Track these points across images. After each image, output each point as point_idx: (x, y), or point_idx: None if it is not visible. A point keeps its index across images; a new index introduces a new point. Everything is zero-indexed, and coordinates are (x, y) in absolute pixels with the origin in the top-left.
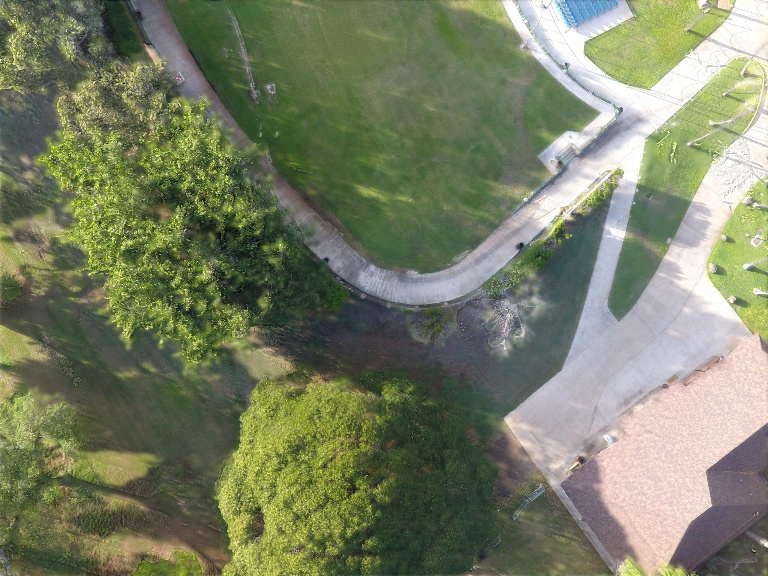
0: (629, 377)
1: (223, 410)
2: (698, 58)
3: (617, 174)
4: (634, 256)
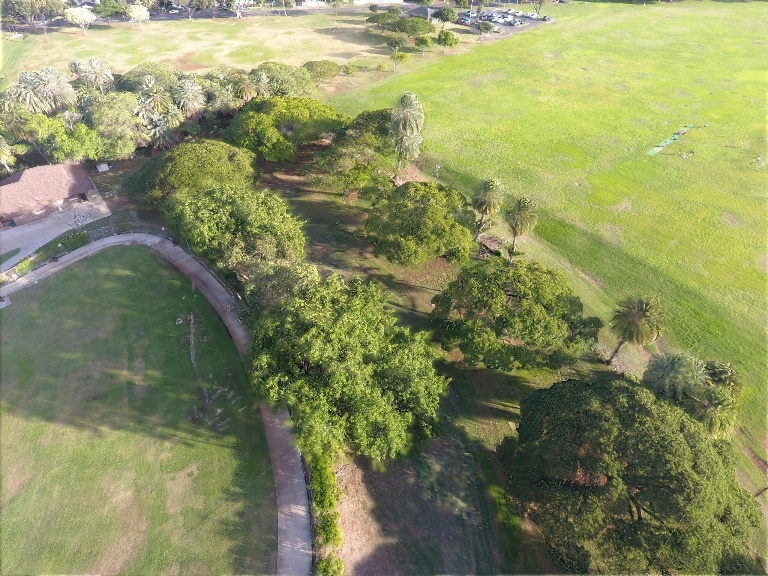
0: (31, 229)
1: None
2: None
3: None
4: None
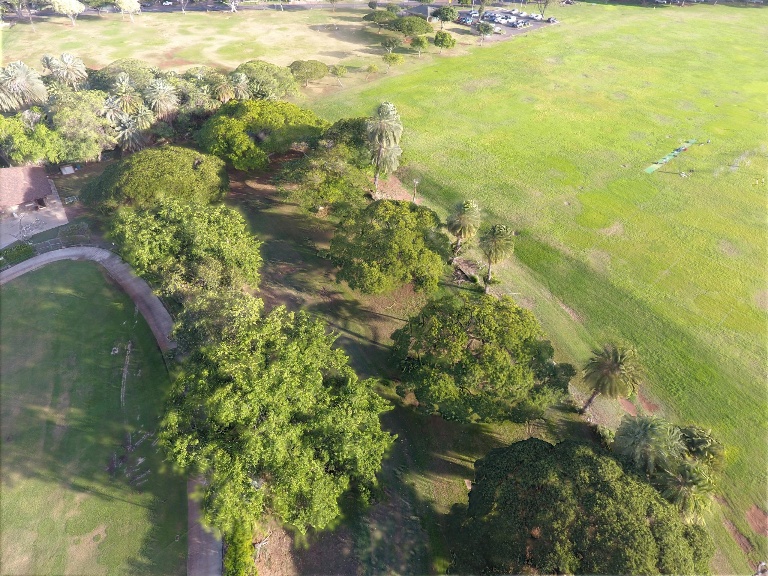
0: None
1: None
2: None
3: None
4: None
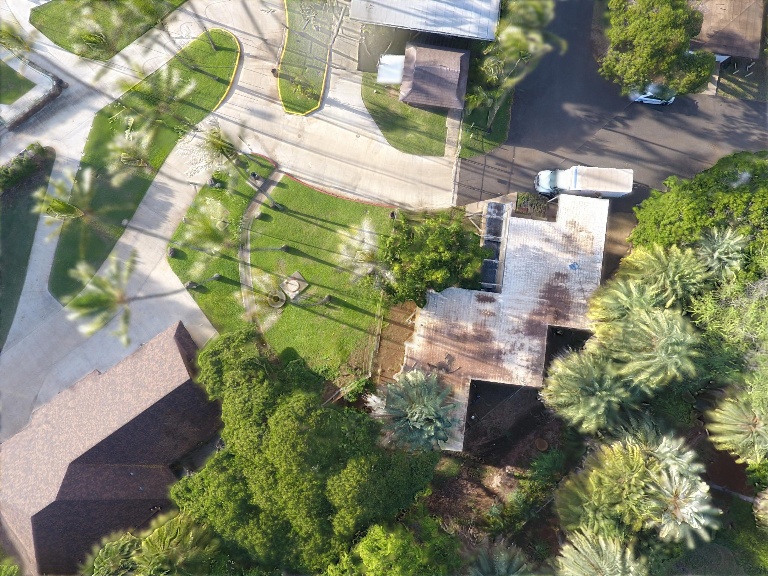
0: (74, 365)
1: None
2: (167, 29)
3: (30, 150)
4: (78, 238)
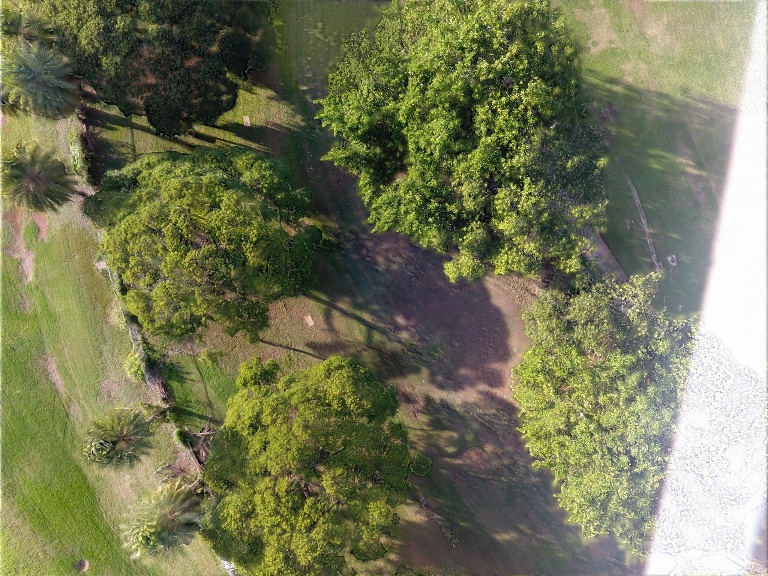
0: None
1: (602, 573)
2: None
3: None
4: None
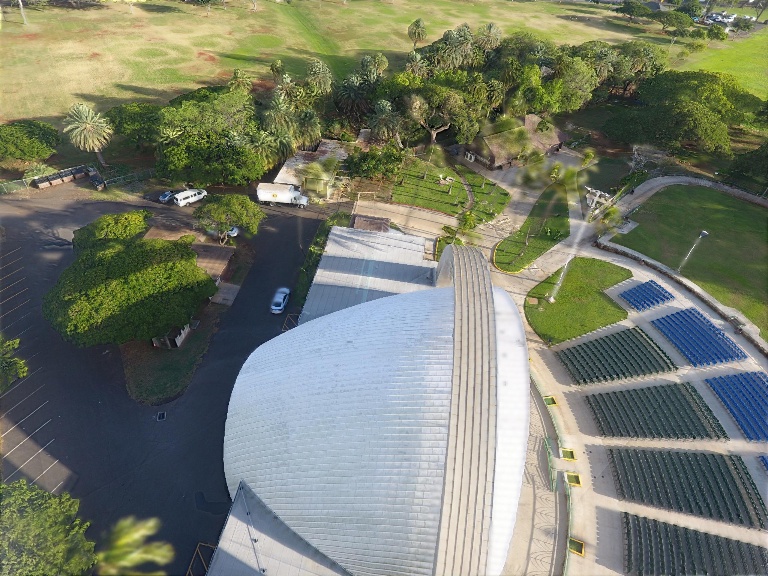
0: None
1: None
2: None
3: None
4: None
